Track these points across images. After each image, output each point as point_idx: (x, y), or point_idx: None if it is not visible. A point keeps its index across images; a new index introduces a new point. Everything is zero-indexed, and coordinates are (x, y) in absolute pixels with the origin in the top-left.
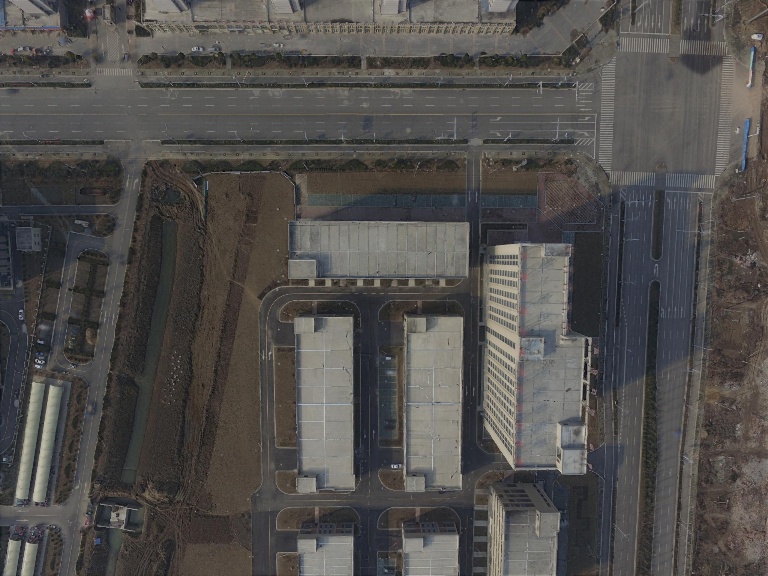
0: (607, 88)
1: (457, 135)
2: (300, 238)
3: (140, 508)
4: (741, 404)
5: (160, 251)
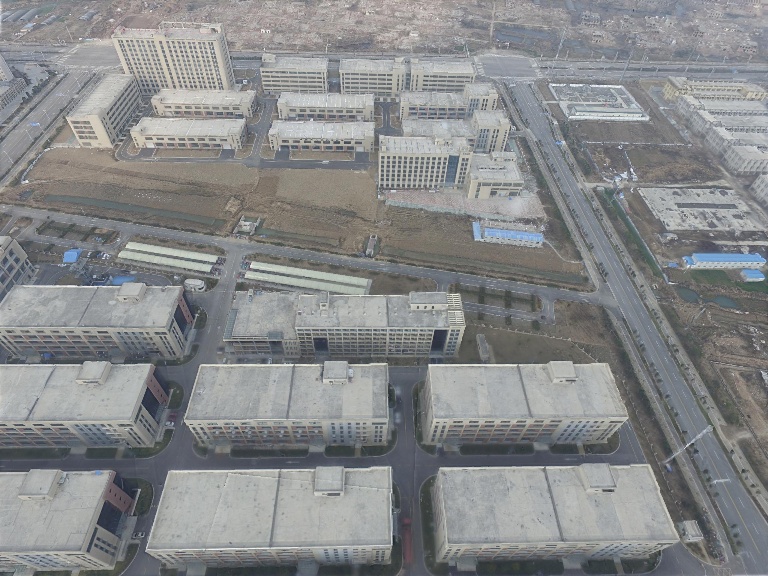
0: (76, 67)
1: (68, 101)
2: (79, 116)
3: (245, 219)
4: (246, 42)
5: None
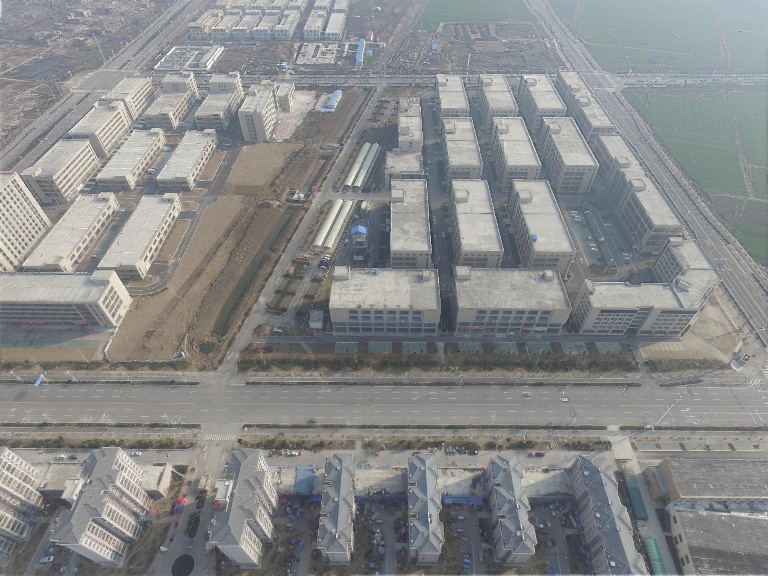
0: None
1: None
2: (97, 295)
3: None
4: None
5: (230, 317)
